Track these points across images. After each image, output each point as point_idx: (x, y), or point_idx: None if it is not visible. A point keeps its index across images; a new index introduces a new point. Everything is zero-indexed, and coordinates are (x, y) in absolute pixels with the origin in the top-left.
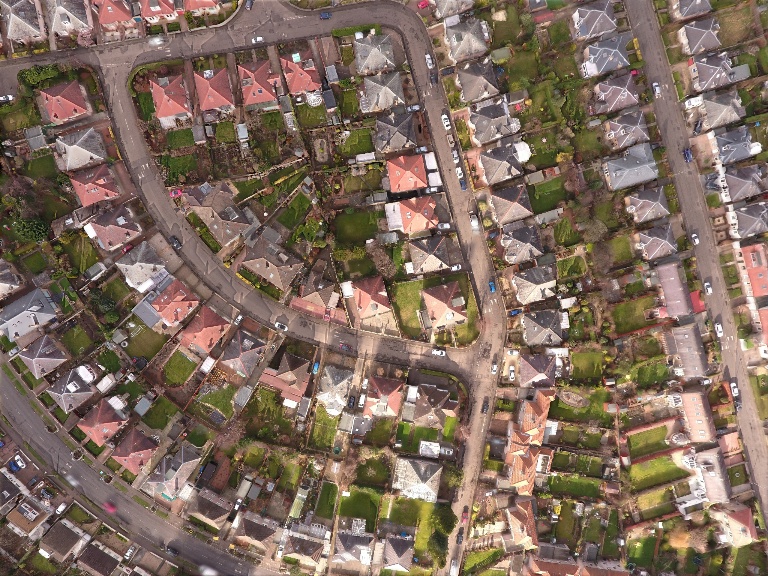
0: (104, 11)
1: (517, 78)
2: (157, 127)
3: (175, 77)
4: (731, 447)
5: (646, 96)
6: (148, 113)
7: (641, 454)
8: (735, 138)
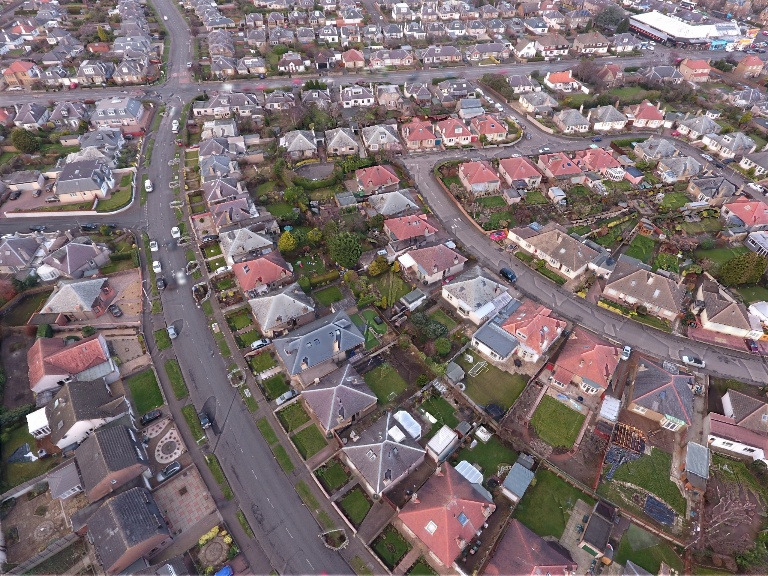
0: (416, 132)
1: None
2: (466, 195)
3: None
4: None
5: None
6: None
7: None
8: None
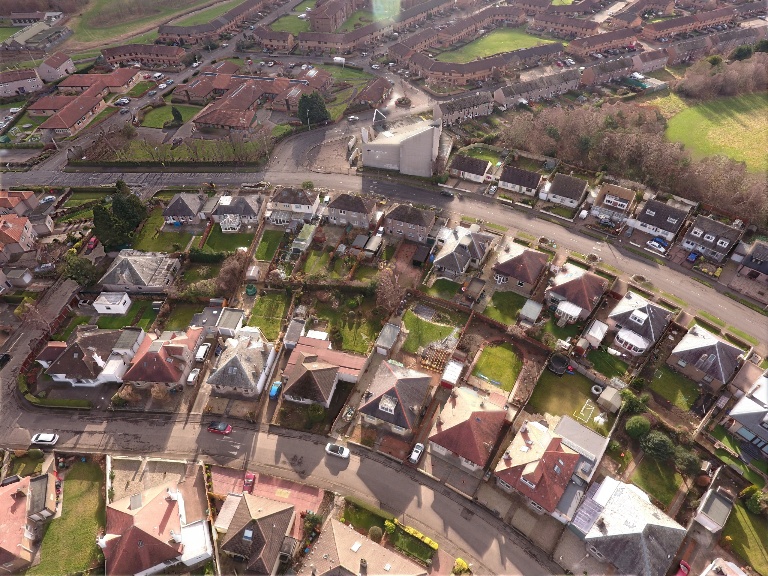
0: None
1: None
2: None
3: None
4: None
5: None
6: None
7: None
8: None
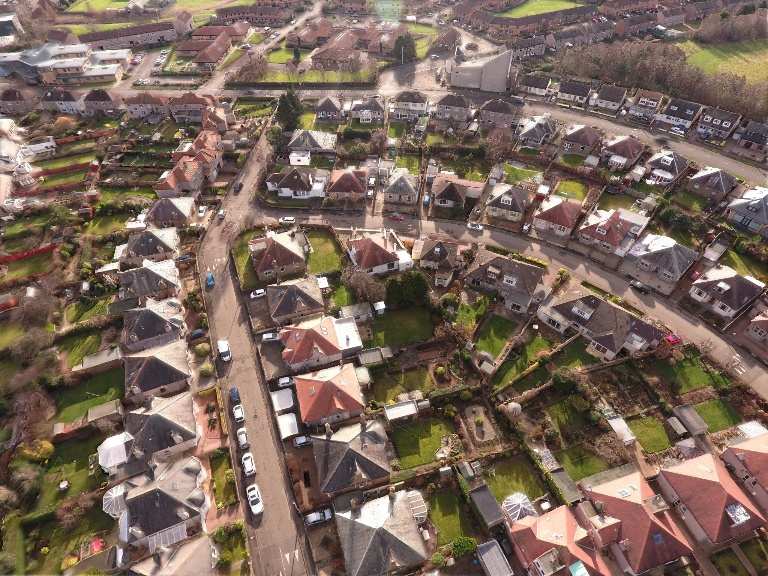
0: None
1: None
2: (765, 427)
3: None
4: None
5: None
6: None
7: (76, 172)
8: None
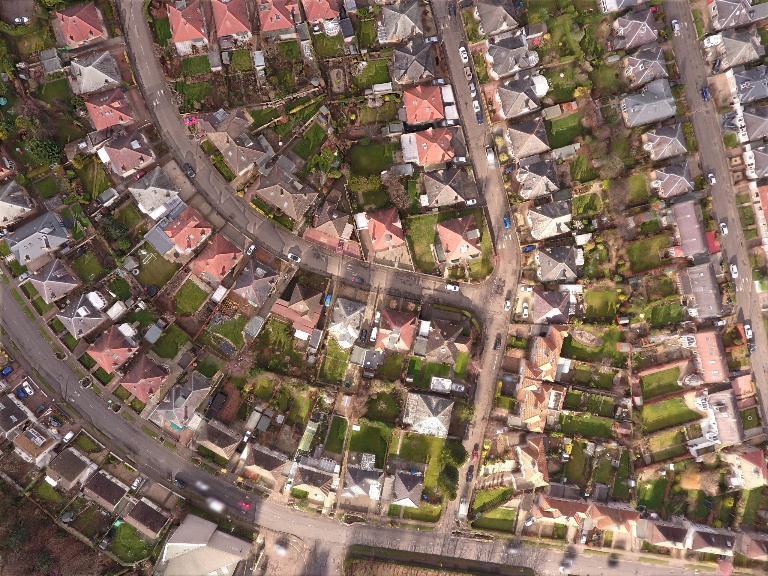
0: None
1: (536, 11)
2: (173, 53)
3: (192, 1)
4: (744, 390)
5: (665, 33)
6: (164, 39)
7: (653, 395)
8: (754, 76)
